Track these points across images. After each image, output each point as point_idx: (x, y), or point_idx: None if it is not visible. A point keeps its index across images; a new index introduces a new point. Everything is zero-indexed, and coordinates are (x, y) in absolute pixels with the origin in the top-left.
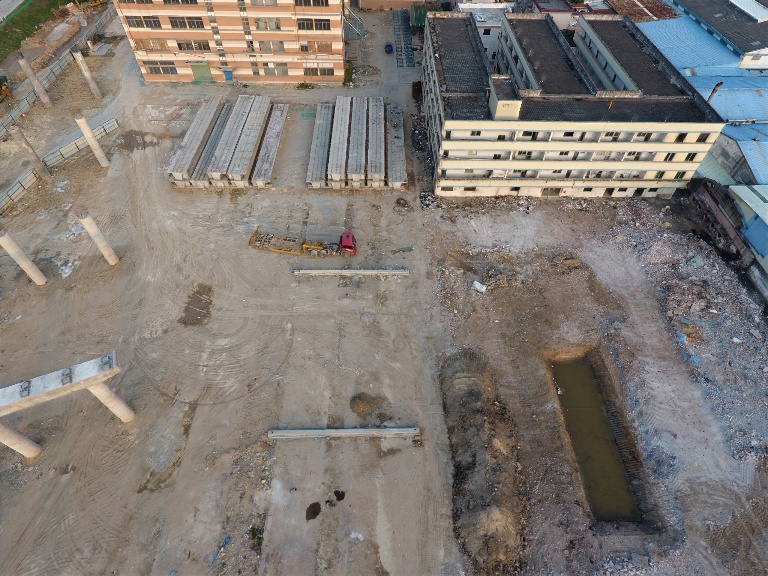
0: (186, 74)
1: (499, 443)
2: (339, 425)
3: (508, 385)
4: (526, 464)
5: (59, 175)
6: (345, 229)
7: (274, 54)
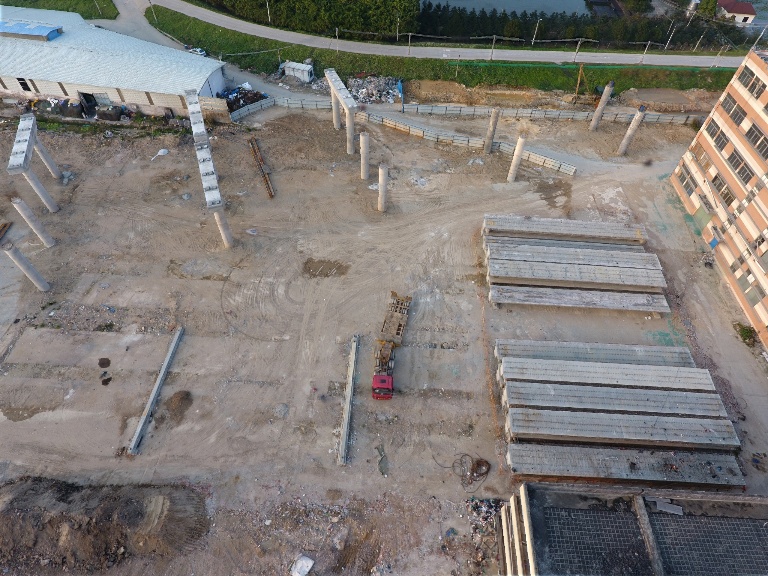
0: (693, 204)
1: (65, 533)
2: (167, 381)
3: (142, 575)
4: (44, 573)
5: (491, 157)
6: (423, 389)
7: (767, 274)
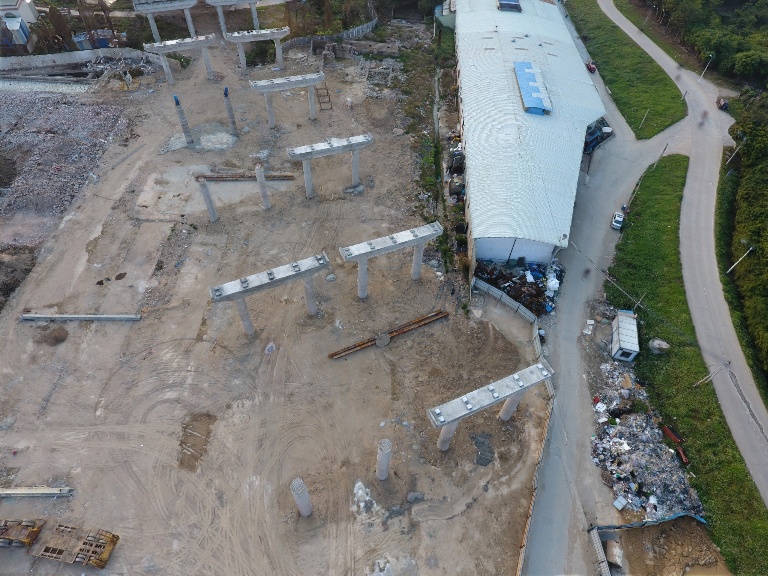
0: None
1: None
2: (83, 322)
3: None
4: None
5: None
6: None
7: None
